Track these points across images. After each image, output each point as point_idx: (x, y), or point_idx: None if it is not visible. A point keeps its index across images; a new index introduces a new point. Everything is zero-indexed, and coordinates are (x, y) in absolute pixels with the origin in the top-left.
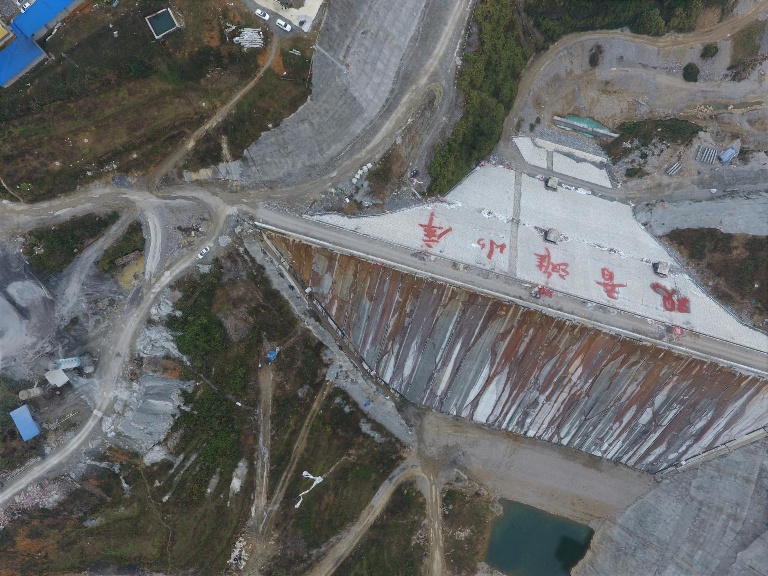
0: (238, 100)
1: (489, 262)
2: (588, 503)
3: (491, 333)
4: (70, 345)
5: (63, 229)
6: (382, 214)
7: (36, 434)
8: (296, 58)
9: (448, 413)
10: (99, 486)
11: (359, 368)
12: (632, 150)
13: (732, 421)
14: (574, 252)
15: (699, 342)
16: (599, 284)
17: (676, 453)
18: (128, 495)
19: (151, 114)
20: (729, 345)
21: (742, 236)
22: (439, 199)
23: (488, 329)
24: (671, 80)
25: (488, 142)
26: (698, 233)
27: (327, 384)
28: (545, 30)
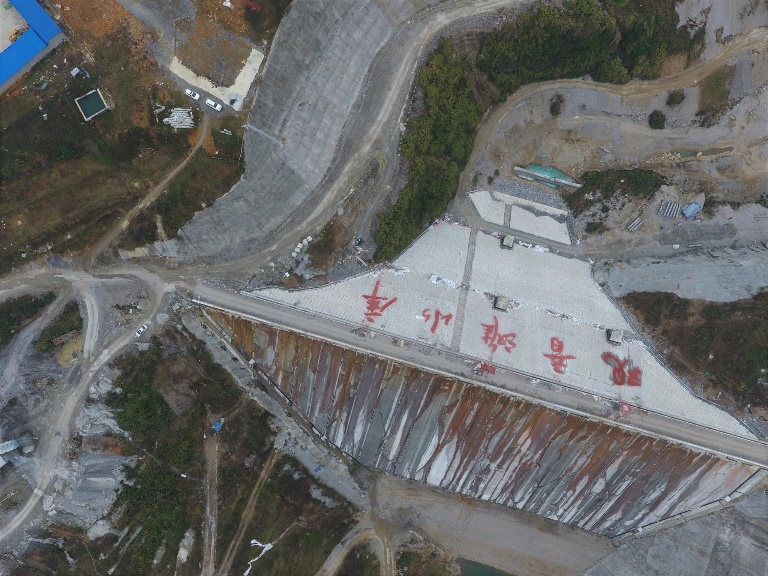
0: (171, 180)
1: (432, 336)
2: (546, 565)
3: (436, 406)
4: (10, 424)
5: None
6: (325, 285)
7: None
8: (227, 138)
9: (401, 476)
10: (43, 561)
11: (309, 433)
12: (594, 202)
13: (686, 493)
14: (524, 320)
15: (647, 419)
16: (546, 356)
17: (632, 520)
18: (73, 568)
19: (84, 195)
20: (678, 422)
21: (699, 302)
22: (387, 265)
23: (433, 402)
24: (636, 128)
25: (439, 203)
26: (654, 297)
27: (275, 452)
28: (501, 83)
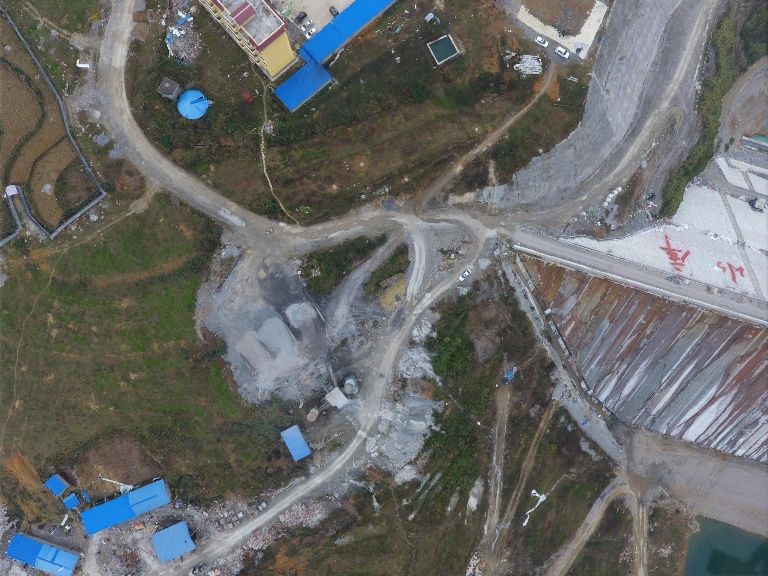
0: (510, 125)
1: (737, 286)
2: None
3: (730, 355)
4: (334, 366)
5: (338, 252)
6: (624, 237)
7: (308, 454)
8: (573, 85)
9: (657, 432)
10: (355, 505)
11: (577, 387)
12: None
13: None
14: None
15: None
16: None
17: None
18: (378, 514)
19: (425, 139)
20: None
21: None
22: (666, 221)
23: (728, 351)
24: None
25: None
26: None
27: (553, 403)
28: (751, 53)
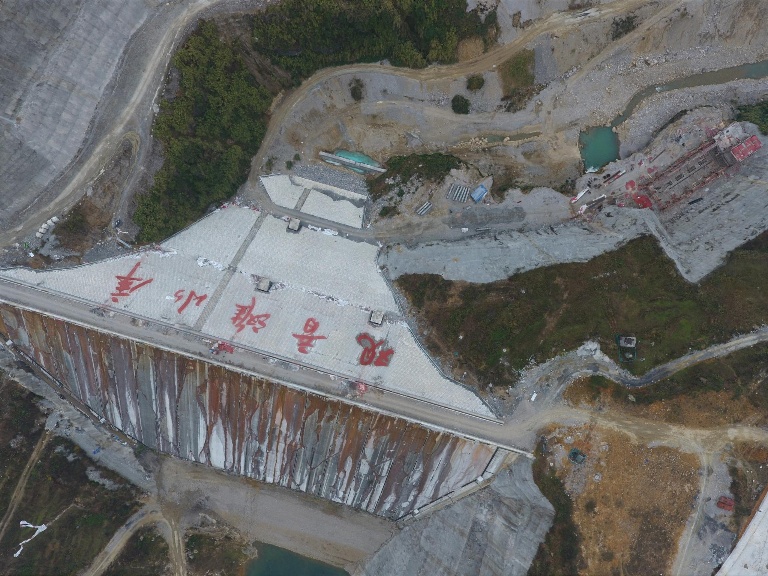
0: None
1: (177, 316)
2: (338, 548)
3: (190, 386)
4: None
5: None
6: (78, 266)
7: None
8: None
9: (187, 459)
10: None
11: (88, 415)
12: (393, 187)
13: (444, 474)
14: (285, 301)
15: (383, 398)
16: (295, 337)
17: (407, 502)
18: None
19: None
20: (414, 401)
21: (460, 283)
22: (154, 247)
23: (185, 382)
24: (440, 112)
25: (217, 186)
26: (421, 279)
27: (47, 433)
28: (288, 67)
